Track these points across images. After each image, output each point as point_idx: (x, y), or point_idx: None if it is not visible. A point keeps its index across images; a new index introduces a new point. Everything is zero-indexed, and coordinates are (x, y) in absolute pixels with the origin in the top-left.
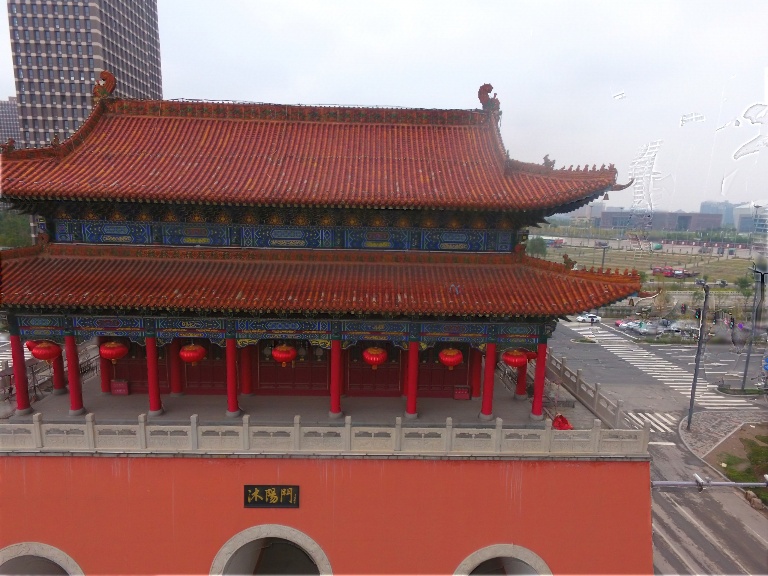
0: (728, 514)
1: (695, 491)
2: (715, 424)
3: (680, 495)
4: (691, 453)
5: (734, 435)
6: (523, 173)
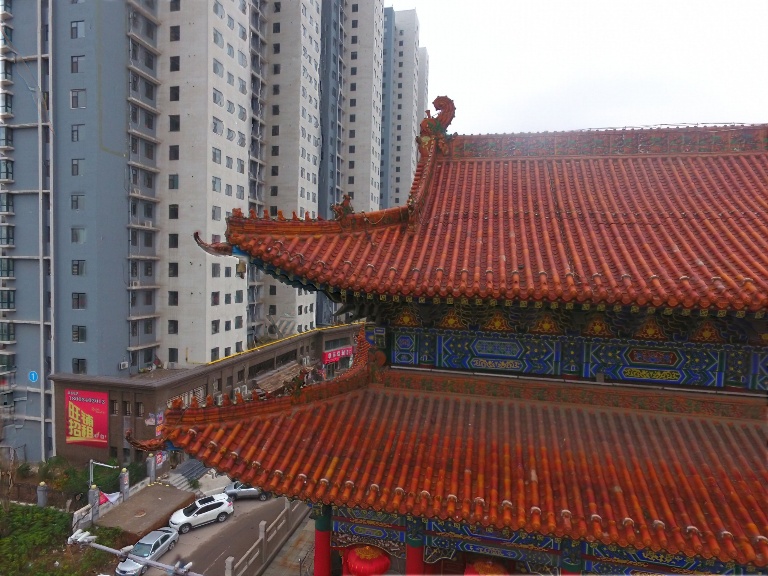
0: None
1: None
2: None
3: None
4: None
5: None
6: None
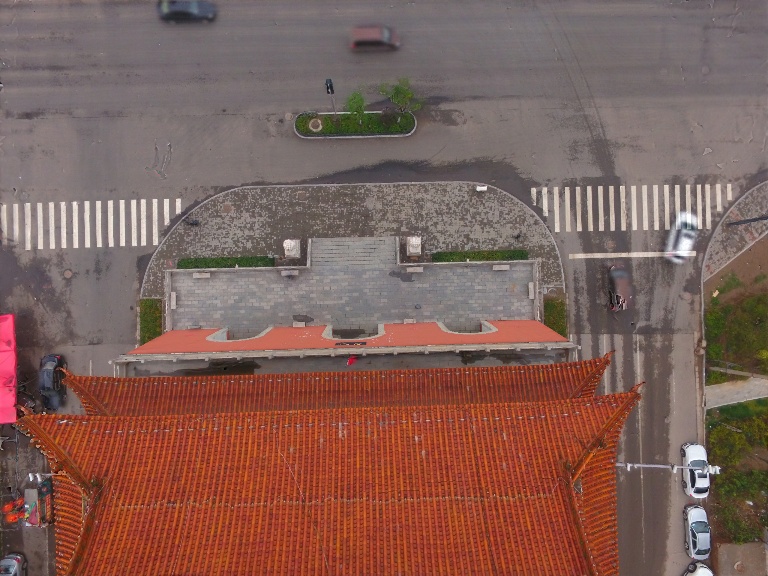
0: (669, 361)
1: (664, 333)
2: (766, 212)
3: (648, 339)
4: (700, 272)
5: (767, 236)
6: None
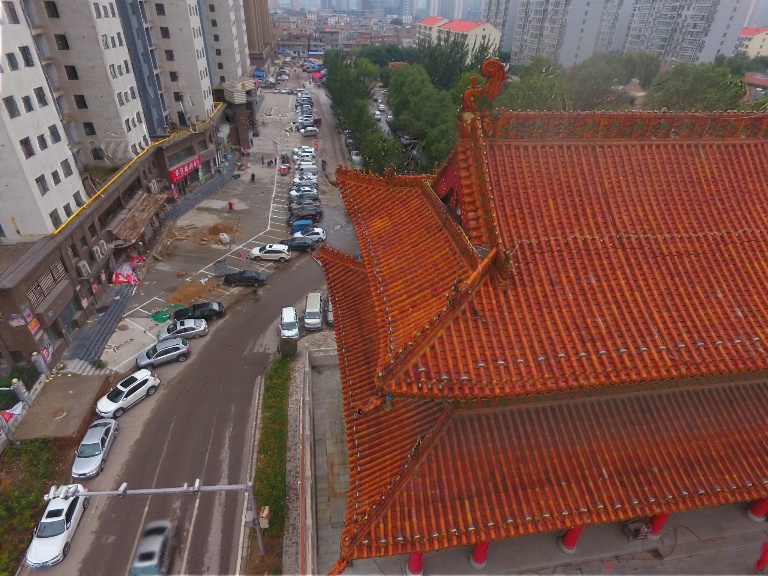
0: None
1: None
2: None
3: None
4: None
5: None
6: (415, 187)
